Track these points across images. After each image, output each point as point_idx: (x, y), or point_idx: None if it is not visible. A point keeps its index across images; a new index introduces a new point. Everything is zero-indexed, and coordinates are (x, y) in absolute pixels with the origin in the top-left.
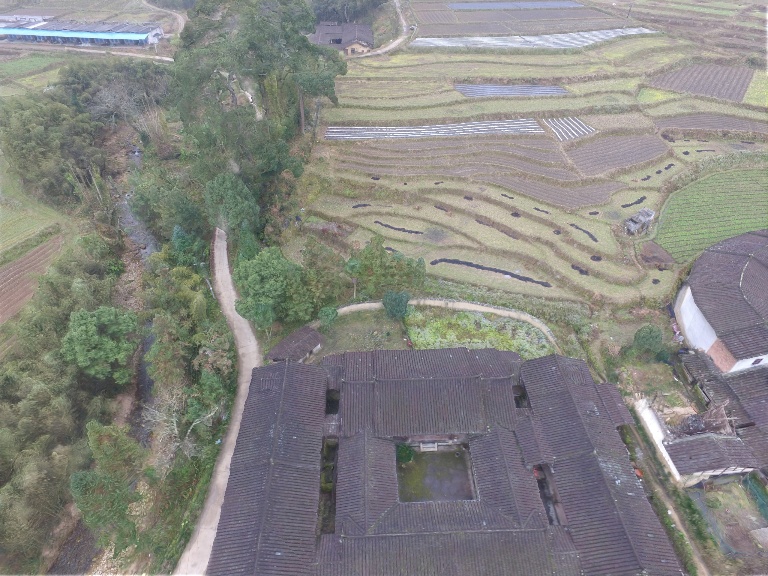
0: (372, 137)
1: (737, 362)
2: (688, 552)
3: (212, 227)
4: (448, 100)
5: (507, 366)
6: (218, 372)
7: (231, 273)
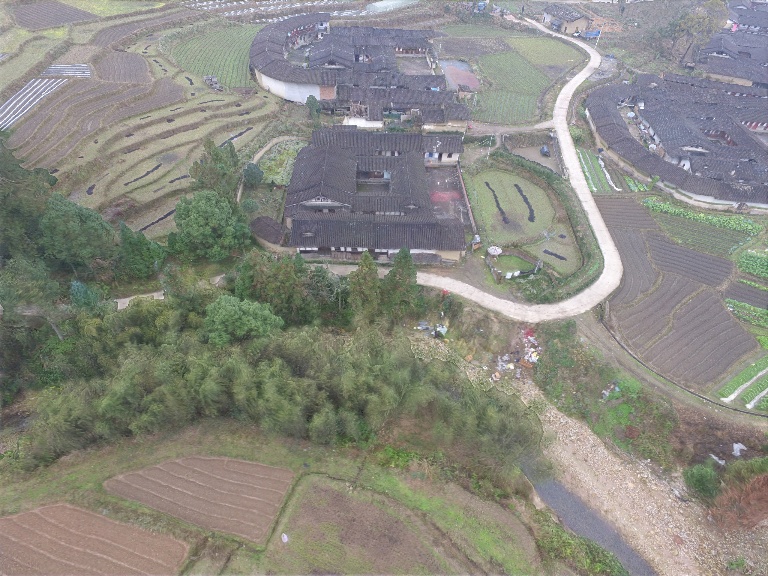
0: None
1: None
2: None
3: None
4: None
5: None
6: None
7: (129, 296)
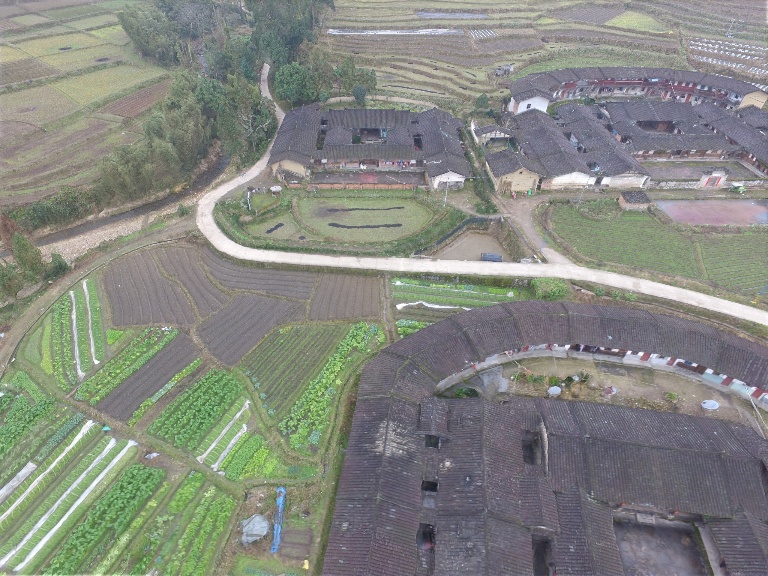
0: (356, 33)
1: (519, 106)
2: (473, 160)
3: (259, 75)
4: (408, 18)
5: (412, 114)
6: (269, 112)
7: (271, 94)
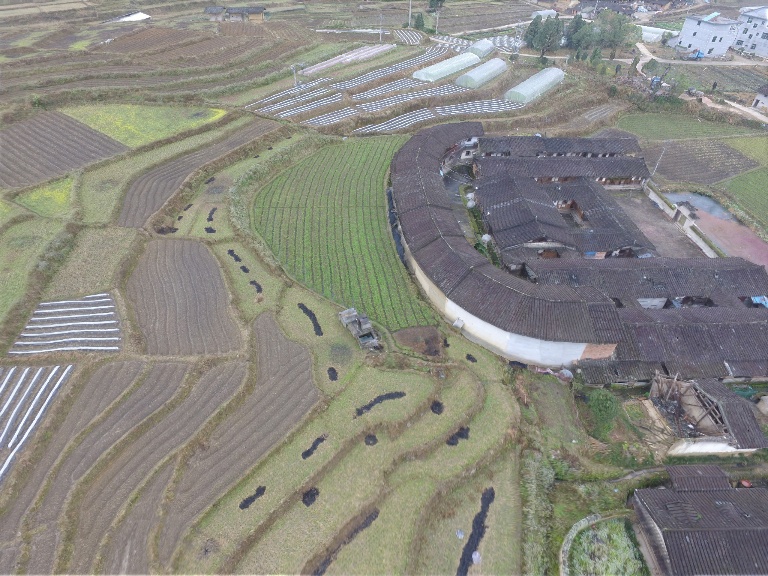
0: None
1: None
2: None
3: None
4: None
5: None
6: None
7: None
